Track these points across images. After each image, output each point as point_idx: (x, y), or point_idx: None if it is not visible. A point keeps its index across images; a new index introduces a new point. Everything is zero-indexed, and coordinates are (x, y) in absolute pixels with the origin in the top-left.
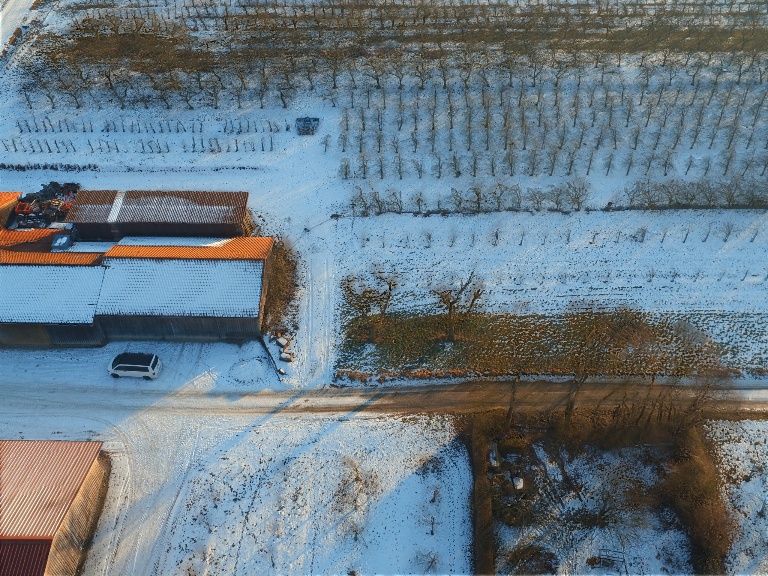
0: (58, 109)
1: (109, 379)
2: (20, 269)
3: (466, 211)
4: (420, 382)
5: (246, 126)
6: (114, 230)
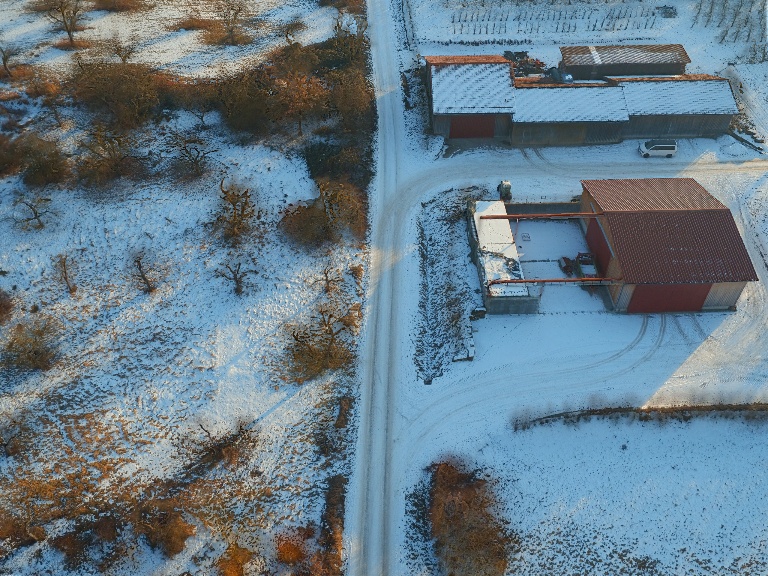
0: (469, 7)
1: (641, 159)
2: (563, 90)
3: None
4: None
5: (623, 13)
6: (593, 72)
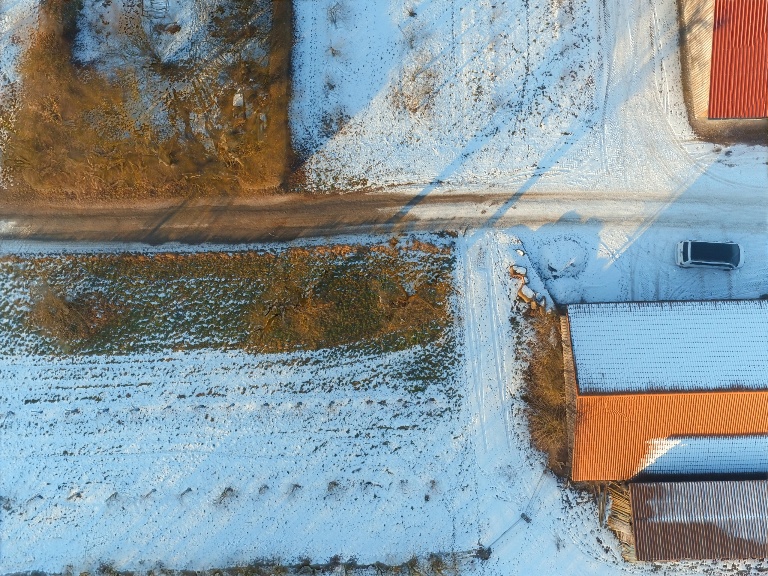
0: None
1: None
2: None
3: (269, 570)
4: (346, 240)
5: None
6: None
